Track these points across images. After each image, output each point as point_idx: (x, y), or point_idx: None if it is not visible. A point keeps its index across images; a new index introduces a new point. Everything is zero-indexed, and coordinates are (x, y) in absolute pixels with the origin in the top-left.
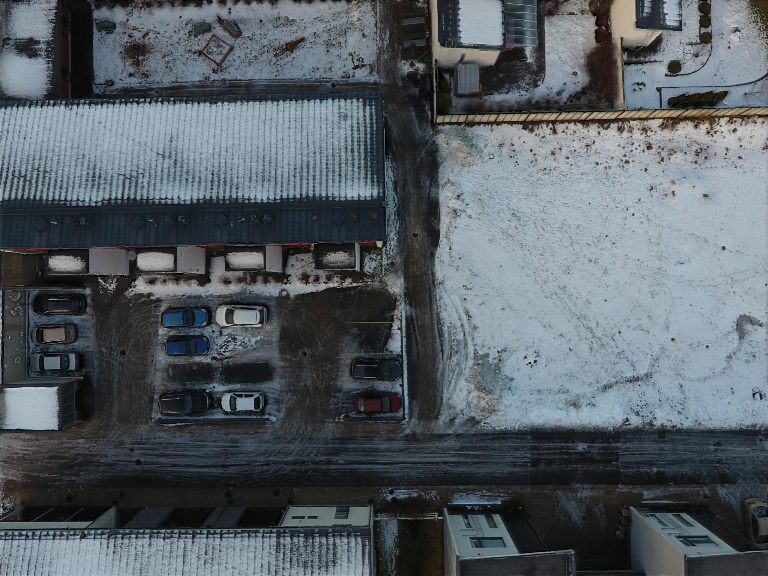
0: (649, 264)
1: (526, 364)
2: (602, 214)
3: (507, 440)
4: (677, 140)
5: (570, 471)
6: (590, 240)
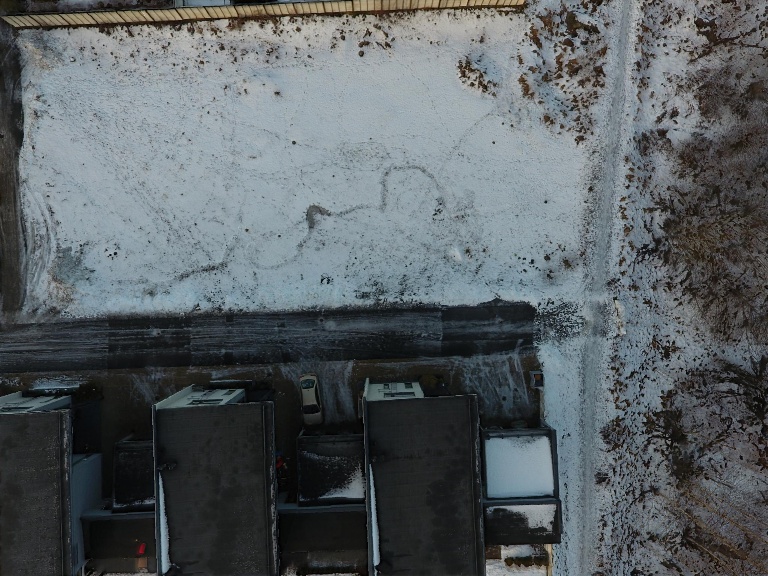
0: (223, 159)
1: (107, 256)
2: (179, 113)
3: (87, 328)
4: (248, 40)
5: (145, 355)
6: (168, 138)
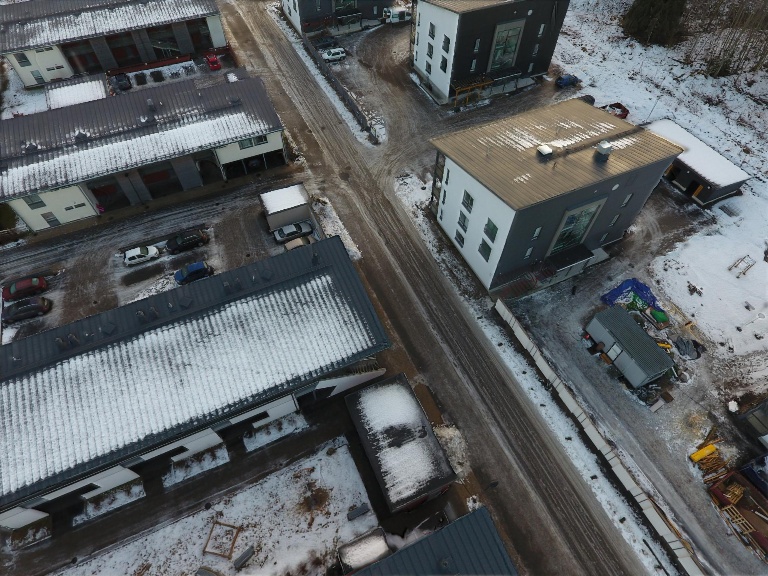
0: None
1: None
2: None
3: None
4: None
5: None
6: None
